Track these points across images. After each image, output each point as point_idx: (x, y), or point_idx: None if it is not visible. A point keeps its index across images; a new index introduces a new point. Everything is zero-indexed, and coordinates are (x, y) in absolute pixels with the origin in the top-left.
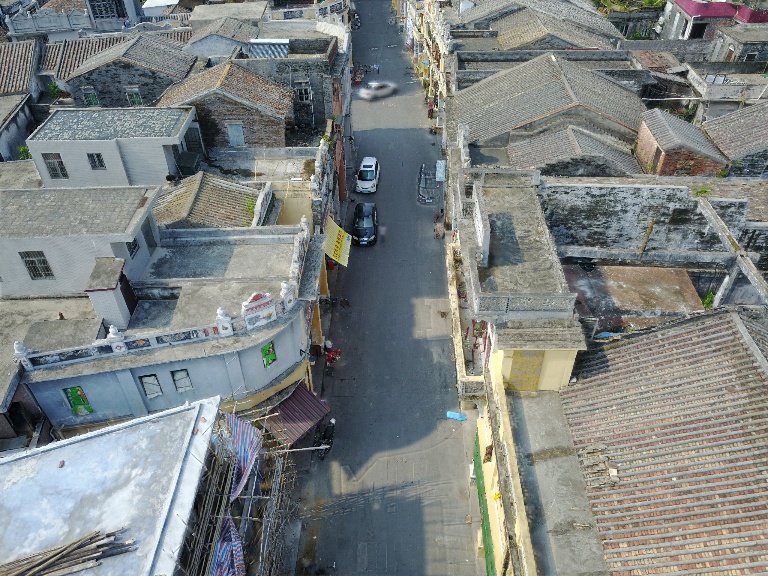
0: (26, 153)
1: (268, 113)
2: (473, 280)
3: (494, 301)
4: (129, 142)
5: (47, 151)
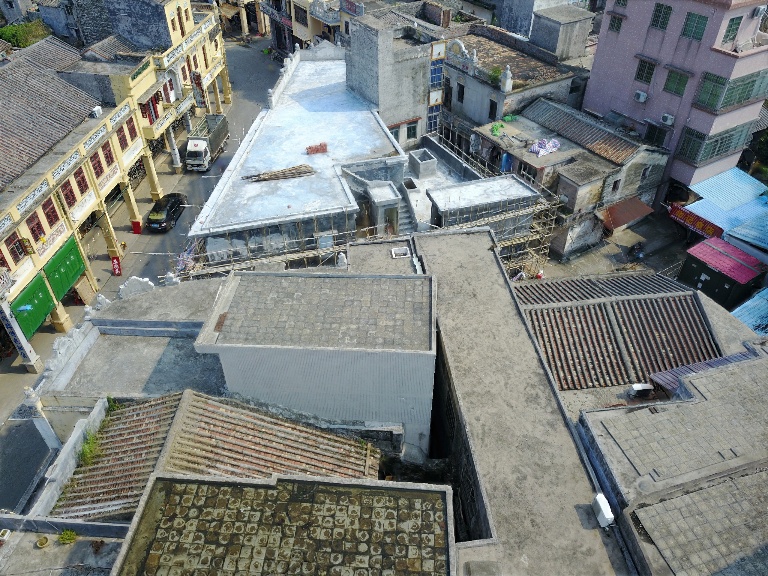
0: None
1: None
2: None
3: None
4: None
5: None
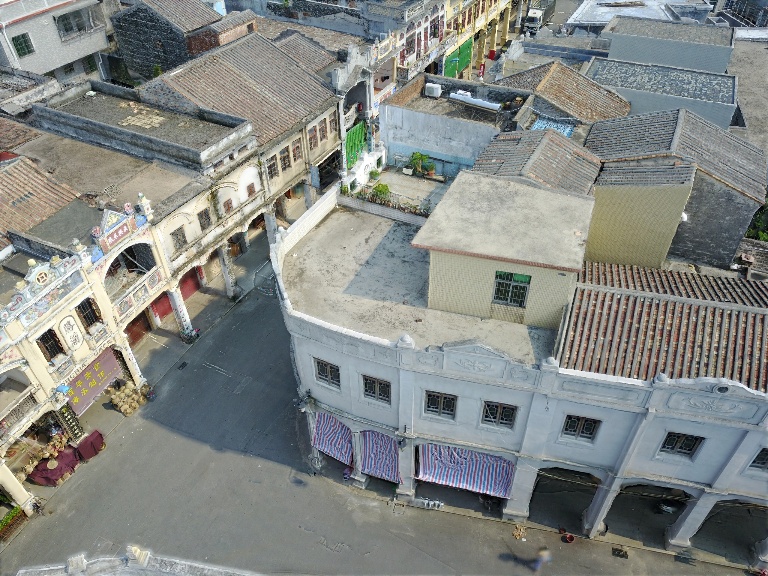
0: None
1: None
2: None
3: None
4: None
5: None
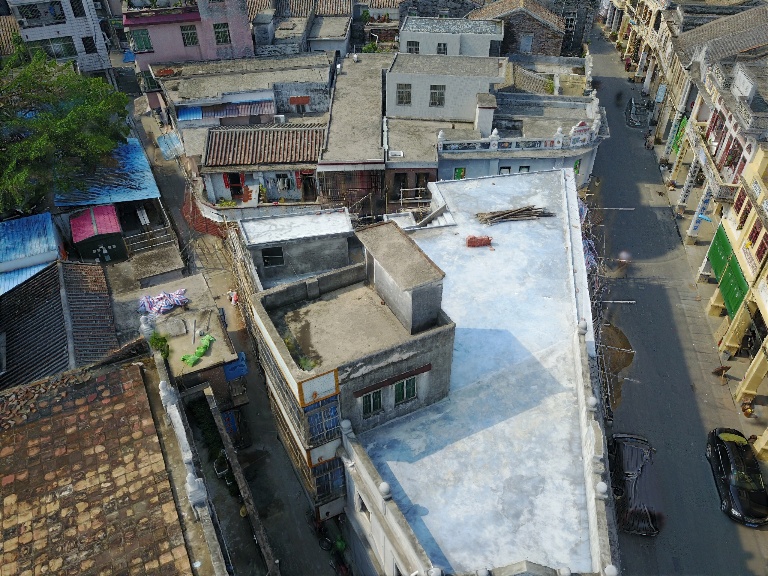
0: (370, 50)
1: (555, 29)
2: (747, 109)
3: (762, 121)
4: (468, 37)
5: (412, 40)
